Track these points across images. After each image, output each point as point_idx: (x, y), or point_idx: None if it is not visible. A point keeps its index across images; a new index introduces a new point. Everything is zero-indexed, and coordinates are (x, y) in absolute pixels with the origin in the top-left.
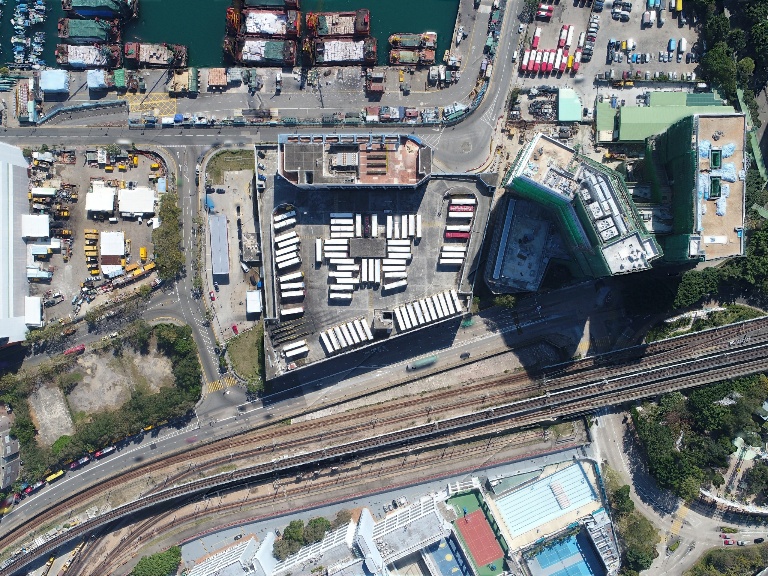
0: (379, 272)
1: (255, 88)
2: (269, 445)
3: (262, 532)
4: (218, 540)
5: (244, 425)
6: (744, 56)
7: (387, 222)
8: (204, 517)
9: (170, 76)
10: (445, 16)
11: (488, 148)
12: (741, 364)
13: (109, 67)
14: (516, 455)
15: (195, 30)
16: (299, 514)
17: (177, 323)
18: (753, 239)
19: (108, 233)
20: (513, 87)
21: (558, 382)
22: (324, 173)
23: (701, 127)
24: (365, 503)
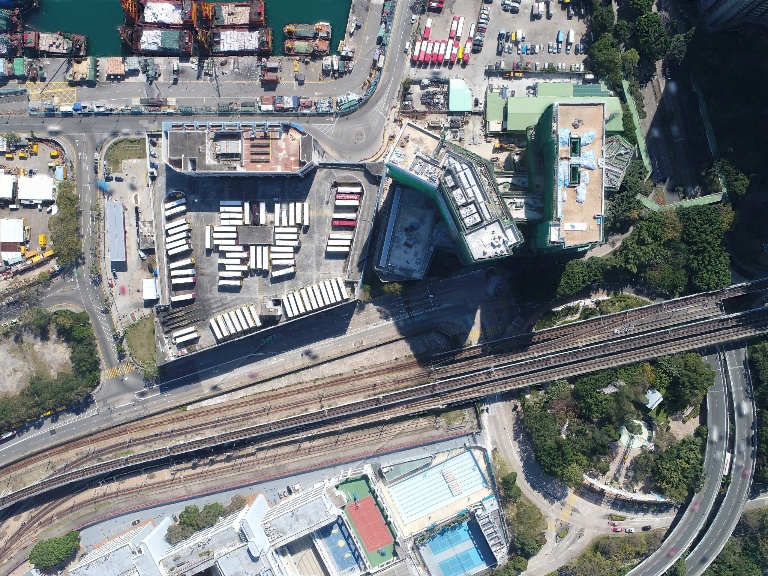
0: (267, 259)
1: (153, 77)
2: (166, 431)
3: (159, 517)
4: (116, 525)
5: (142, 411)
6: None
7: (275, 210)
8: (103, 502)
9: (70, 65)
10: (340, 7)
11: (381, 138)
12: (625, 353)
13: (10, 56)
14: (408, 442)
15: (95, 19)
16: (196, 500)
17: (76, 310)
18: (635, 228)
19: (8, 220)
20: (405, 77)
21: (447, 370)
22: None
23: (561, 115)
24: (260, 489)
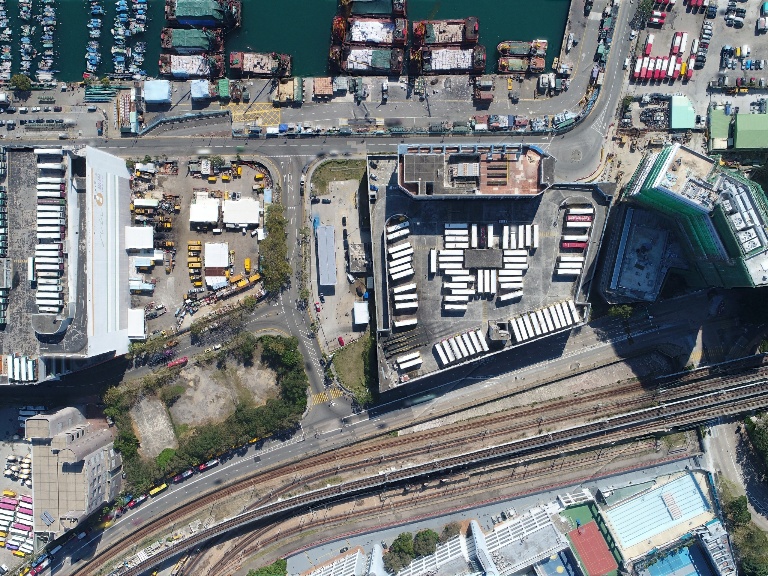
0: (495, 283)
1: (361, 97)
2: (376, 457)
3: (368, 545)
4: (323, 553)
5: (350, 437)
6: None
7: (503, 232)
8: (309, 530)
9: (274, 86)
10: (554, 23)
11: (599, 156)
12: None
13: (212, 77)
14: (627, 466)
15: (299, 39)
16: (406, 526)
17: (281, 335)
18: None
19: (212, 244)
20: (624, 95)
21: (672, 392)
22: None
23: None
24: (473, 515)
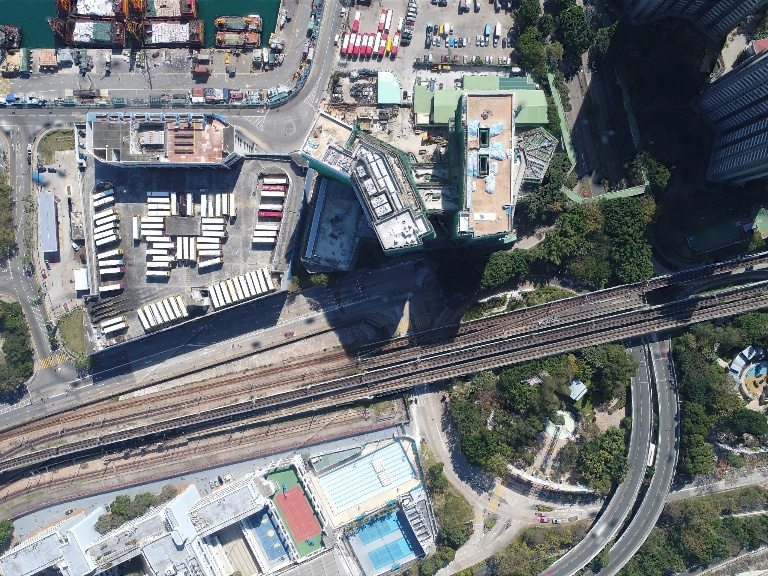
0: (193, 250)
1: (85, 69)
2: (98, 421)
3: (92, 507)
4: (50, 515)
5: (75, 401)
6: (558, 41)
7: (201, 201)
8: (36, 492)
9: (3, 57)
10: None
11: None
12: (550, 344)
13: None
14: (338, 433)
15: (28, 11)
16: (128, 490)
17: (10, 300)
18: (558, 220)
19: None
20: (335, 70)
21: (375, 361)
22: (132, 151)
23: (470, 106)
24: (192, 479)
